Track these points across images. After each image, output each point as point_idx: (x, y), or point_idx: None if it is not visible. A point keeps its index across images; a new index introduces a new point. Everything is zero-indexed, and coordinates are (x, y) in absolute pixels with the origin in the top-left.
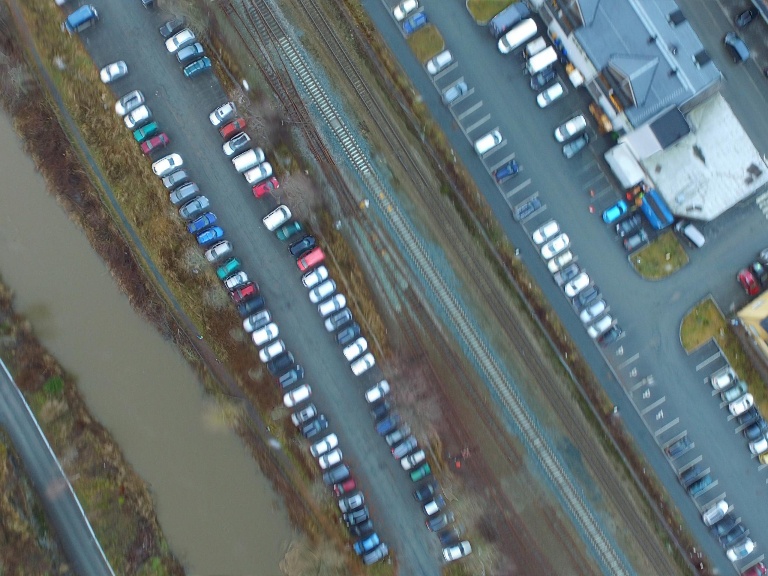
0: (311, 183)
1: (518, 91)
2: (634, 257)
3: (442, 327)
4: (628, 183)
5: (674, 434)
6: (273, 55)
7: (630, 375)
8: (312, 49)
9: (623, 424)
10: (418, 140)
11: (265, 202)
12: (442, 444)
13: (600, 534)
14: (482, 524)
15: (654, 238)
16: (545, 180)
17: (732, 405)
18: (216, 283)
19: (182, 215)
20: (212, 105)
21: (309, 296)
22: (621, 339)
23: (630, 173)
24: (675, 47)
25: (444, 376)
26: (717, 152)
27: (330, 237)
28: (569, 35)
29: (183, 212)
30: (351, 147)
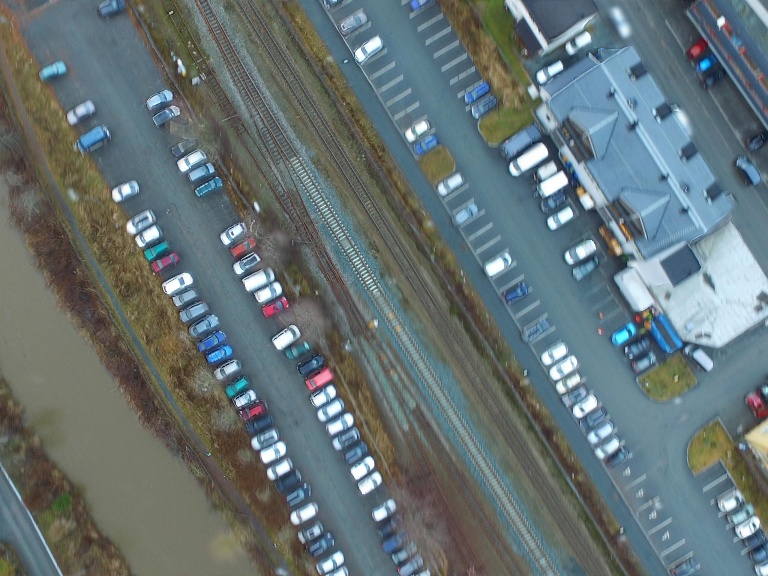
0: (320, 302)
1: (528, 213)
2: (642, 379)
3: (449, 446)
4: (637, 308)
5: (680, 555)
6: (284, 175)
7: (637, 496)
8: (323, 169)
9: (629, 545)
10: (428, 260)
11: (274, 321)
12: (448, 563)
13: None
14: None
15: (662, 360)
16: (554, 302)
17: (738, 528)
18: (225, 402)
19: (192, 334)
20: (223, 224)
21: (317, 415)
22: (628, 460)
23: (639, 299)
24: (687, 185)
25: (451, 495)
26: (727, 279)
27: (339, 357)
28: (580, 163)
29: (193, 331)
30: (361, 267)
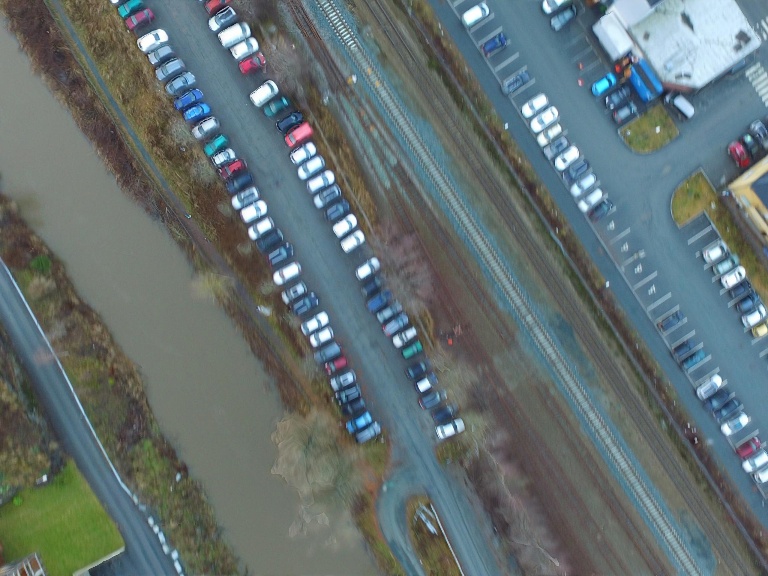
0: (298, 59)
1: None
2: (624, 130)
3: (432, 203)
4: (616, 53)
5: (666, 309)
6: None
7: (621, 250)
8: None
9: (615, 299)
10: (405, 14)
11: (252, 78)
12: (434, 321)
13: (594, 411)
14: (475, 402)
15: (644, 111)
16: (533, 53)
17: (724, 277)
18: (203, 160)
19: (168, 91)
20: None
21: (297, 173)
22: (612, 214)
23: (618, 42)
24: None
25: (435, 253)
26: (705, 19)
27: (318, 113)
28: None
29: (169, 88)
30: (338, 22)
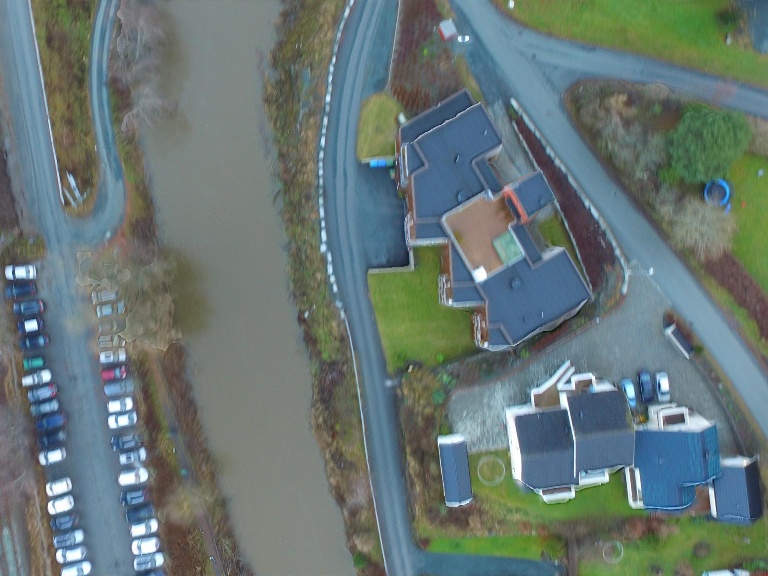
0: None
1: None
2: None
3: None
4: None
5: None
6: None
7: None
8: None
9: None
10: None
11: None
12: (4, 383)
13: None
14: None
15: None
16: None
17: None
18: None
19: None
20: None
21: (92, 569)
22: None
23: None
24: None
25: None
26: None
27: None
28: None
29: None
30: None
